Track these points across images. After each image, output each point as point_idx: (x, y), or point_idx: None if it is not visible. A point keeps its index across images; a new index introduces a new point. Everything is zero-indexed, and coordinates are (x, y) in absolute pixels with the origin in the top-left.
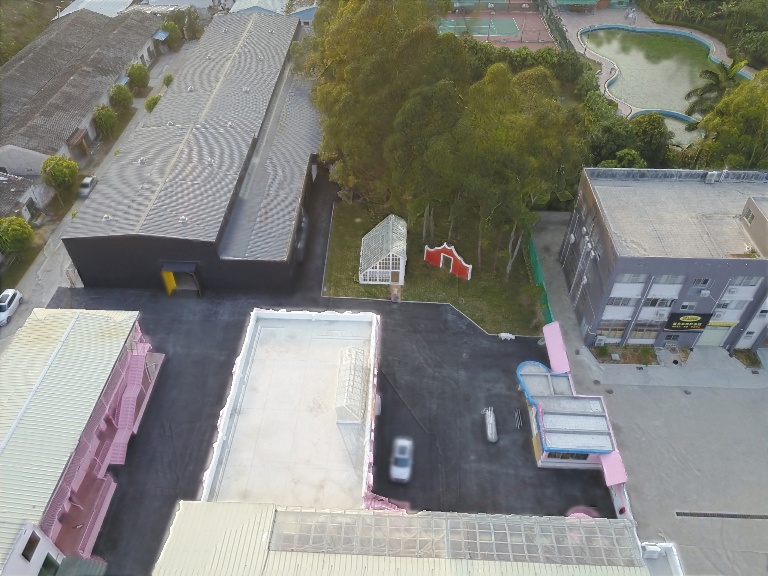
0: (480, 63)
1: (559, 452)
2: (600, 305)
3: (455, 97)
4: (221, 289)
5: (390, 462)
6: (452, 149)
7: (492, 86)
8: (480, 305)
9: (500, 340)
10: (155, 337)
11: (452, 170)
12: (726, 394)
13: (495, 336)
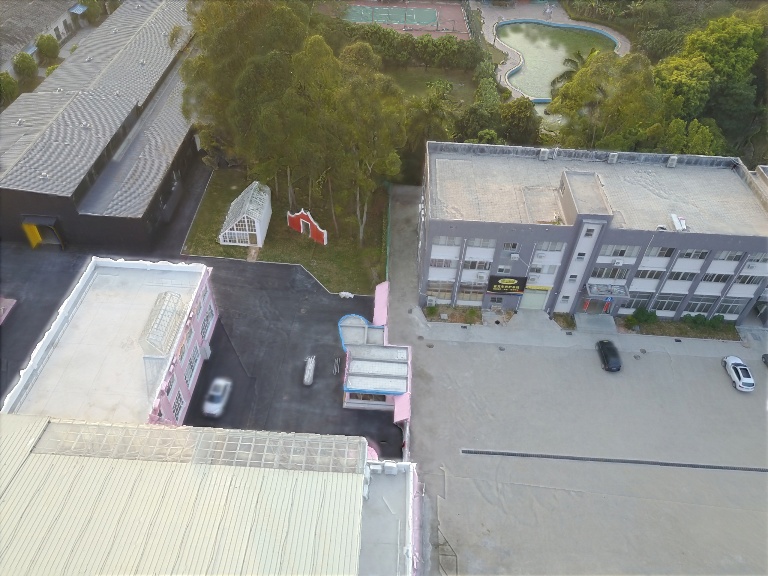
0: (383, 48)
1: (358, 393)
2: (424, 266)
3: (288, 67)
4: (84, 244)
5: (206, 399)
6: (281, 115)
7: (310, 56)
8: (330, 267)
9: (339, 298)
10: (11, 285)
11: (284, 135)
12: (536, 351)
13: (335, 294)
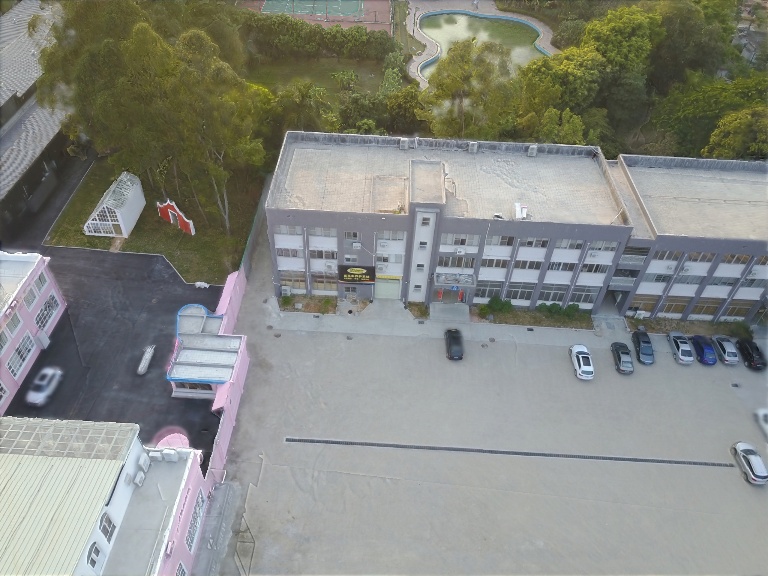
0: (291, 38)
1: (183, 382)
2: (271, 256)
3: None
4: None
5: (33, 389)
6: (116, 103)
7: (135, 44)
8: (192, 257)
9: (194, 288)
10: None
11: (121, 124)
12: (384, 340)
13: (191, 285)
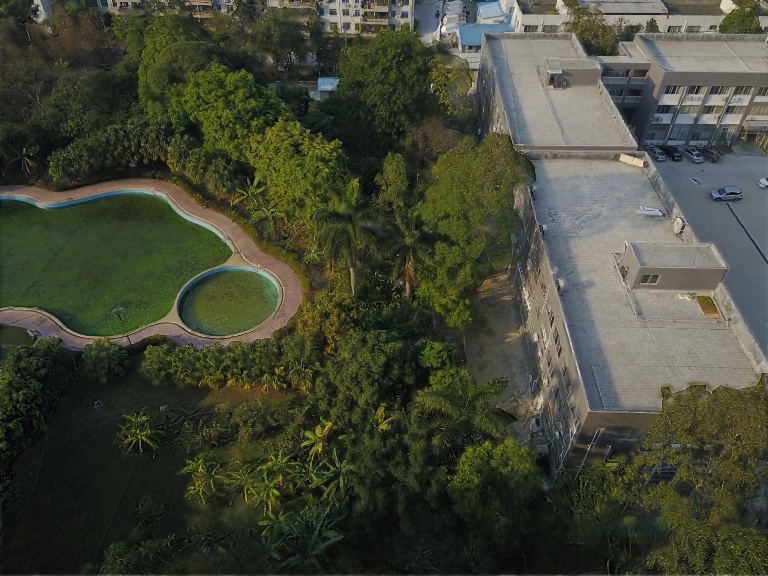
0: None
1: None
2: None
3: None
4: None
5: None
6: None
7: None
8: None
9: None
10: None
11: None
12: None
13: None
